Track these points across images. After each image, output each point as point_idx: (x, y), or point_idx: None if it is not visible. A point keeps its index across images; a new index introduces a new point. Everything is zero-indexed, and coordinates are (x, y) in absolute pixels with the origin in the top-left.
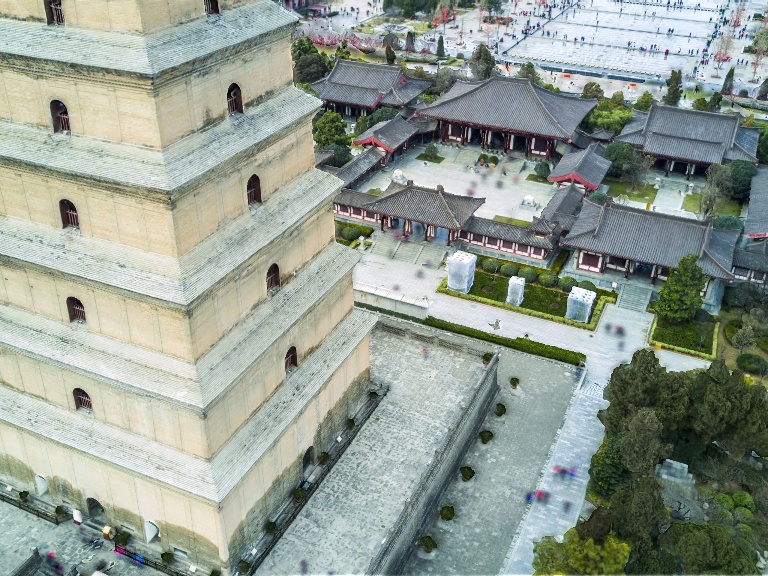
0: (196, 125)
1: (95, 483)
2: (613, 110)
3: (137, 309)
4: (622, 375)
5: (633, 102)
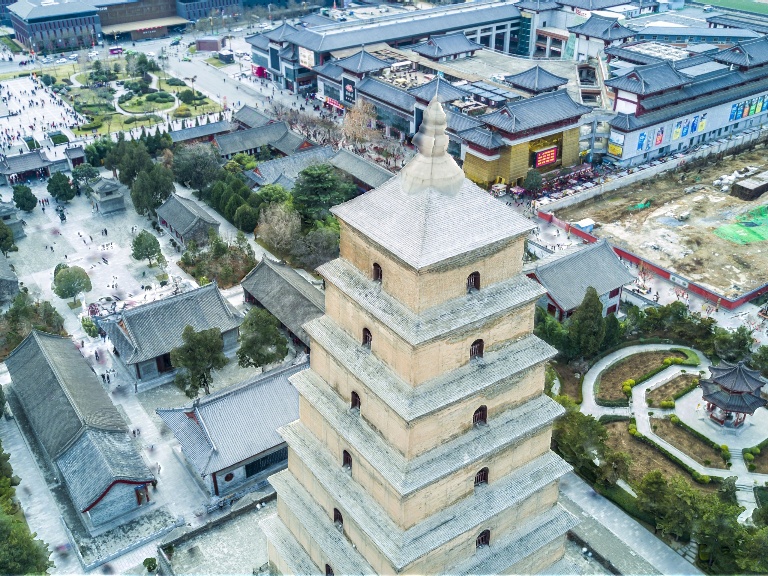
0: None
1: None
2: None
3: None
4: None
5: None
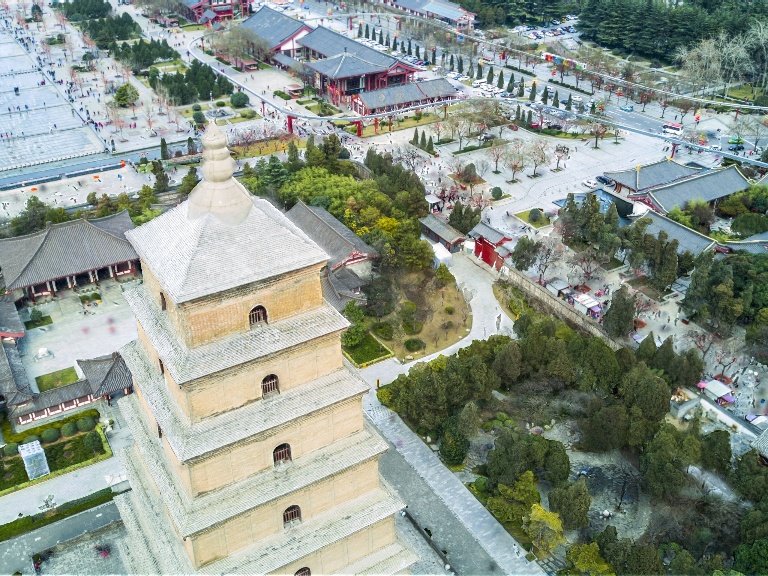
0: None
1: None
2: (143, 212)
3: None
4: (429, 394)
5: (134, 196)
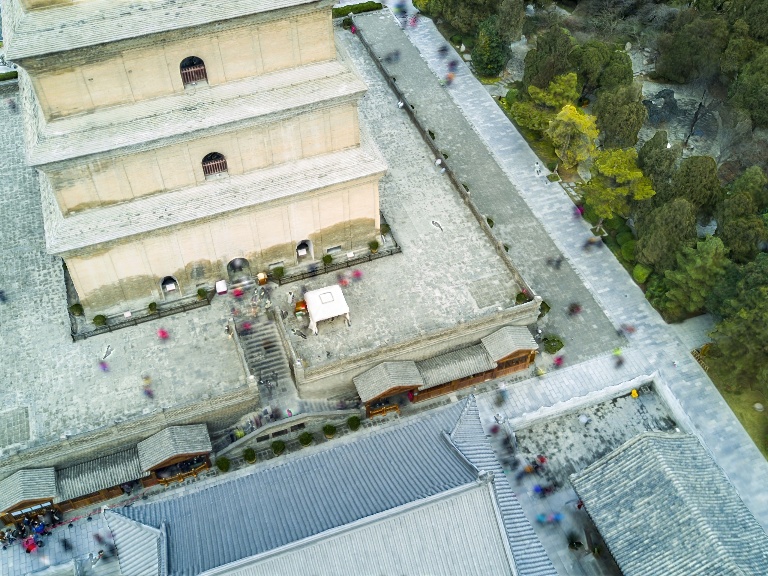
0: None
1: (240, 240)
2: None
3: (273, 32)
4: None
5: None
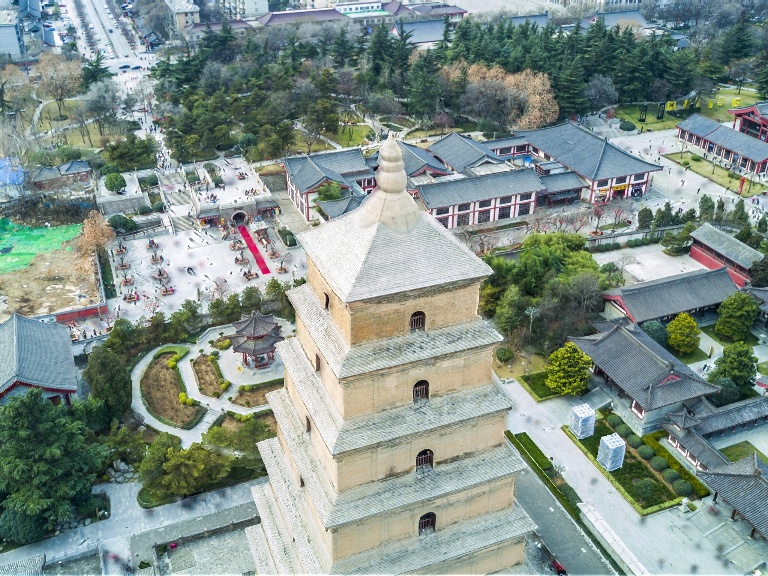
0: (377, 477)
1: None
2: None
3: None
4: None
5: None
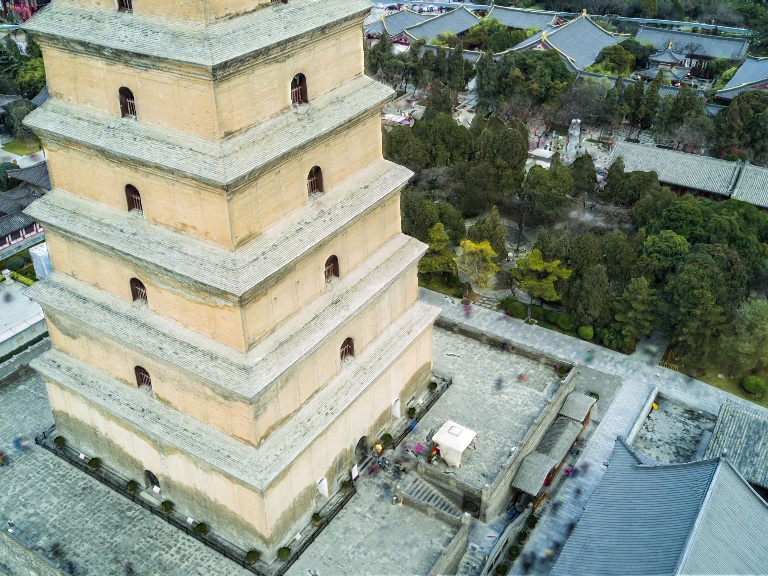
0: None
1: (364, 418)
2: None
3: None
4: None
5: None
